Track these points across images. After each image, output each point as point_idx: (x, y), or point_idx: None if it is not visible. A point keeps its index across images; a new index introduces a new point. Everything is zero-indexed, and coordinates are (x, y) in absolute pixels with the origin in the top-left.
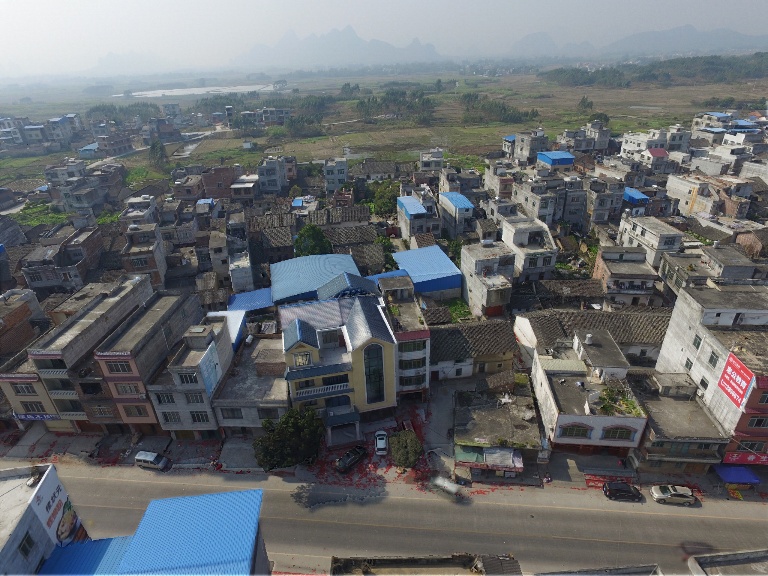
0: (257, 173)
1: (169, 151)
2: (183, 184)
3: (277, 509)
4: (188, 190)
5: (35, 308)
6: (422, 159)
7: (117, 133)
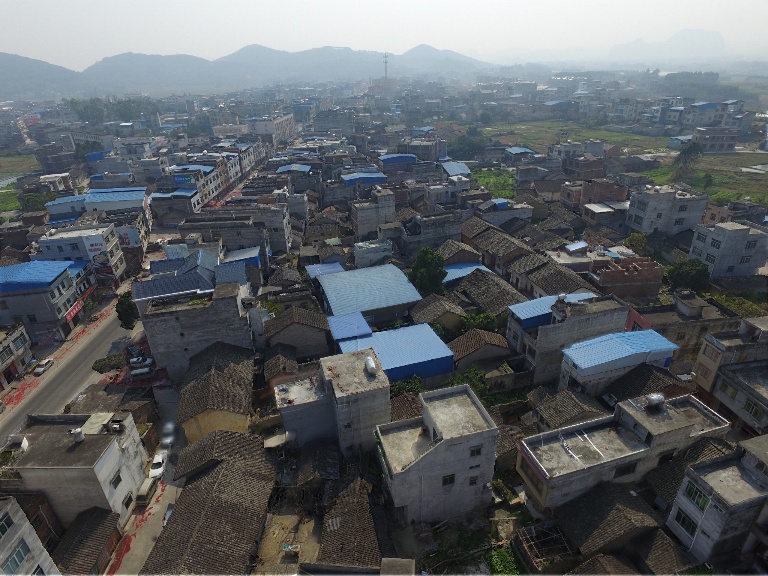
0: (630, 201)
1: (762, 161)
2: (571, 186)
3: (119, 332)
4: None
5: (302, 209)
6: None
7: (729, 128)
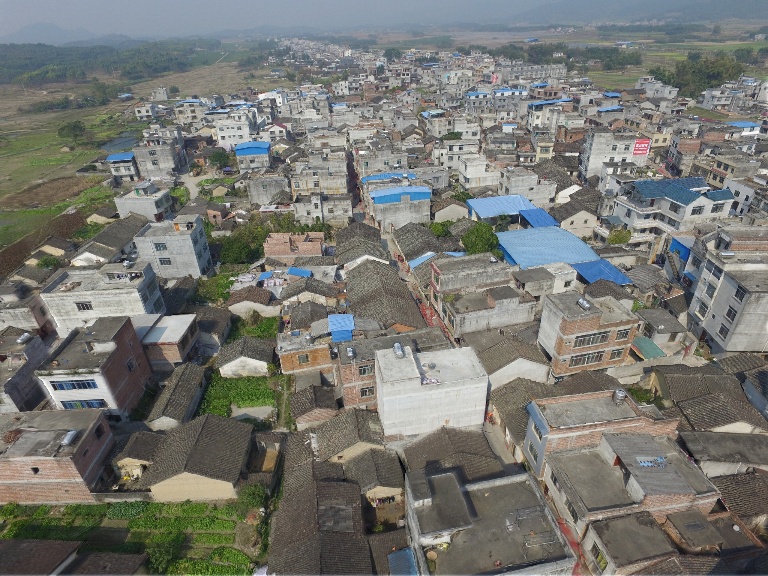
0: (141, 302)
1: None
2: None
3: None
4: (95, 432)
5: None
6: (153, 199)
7: None
